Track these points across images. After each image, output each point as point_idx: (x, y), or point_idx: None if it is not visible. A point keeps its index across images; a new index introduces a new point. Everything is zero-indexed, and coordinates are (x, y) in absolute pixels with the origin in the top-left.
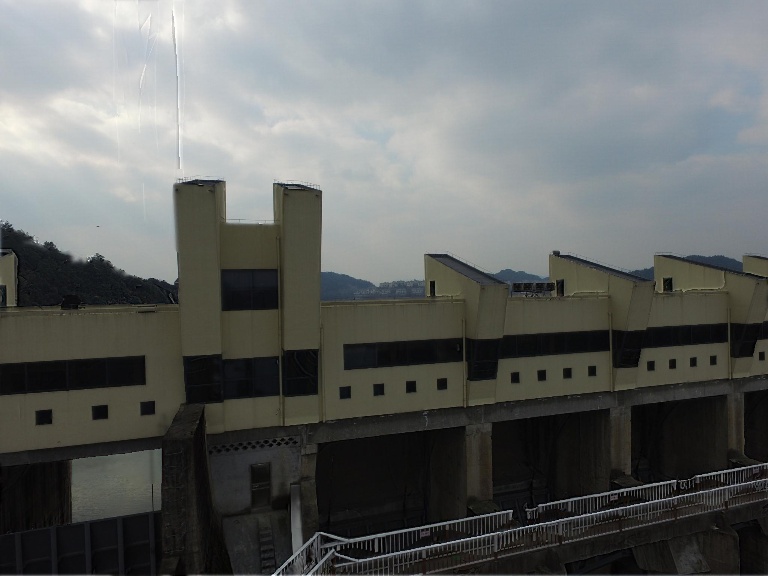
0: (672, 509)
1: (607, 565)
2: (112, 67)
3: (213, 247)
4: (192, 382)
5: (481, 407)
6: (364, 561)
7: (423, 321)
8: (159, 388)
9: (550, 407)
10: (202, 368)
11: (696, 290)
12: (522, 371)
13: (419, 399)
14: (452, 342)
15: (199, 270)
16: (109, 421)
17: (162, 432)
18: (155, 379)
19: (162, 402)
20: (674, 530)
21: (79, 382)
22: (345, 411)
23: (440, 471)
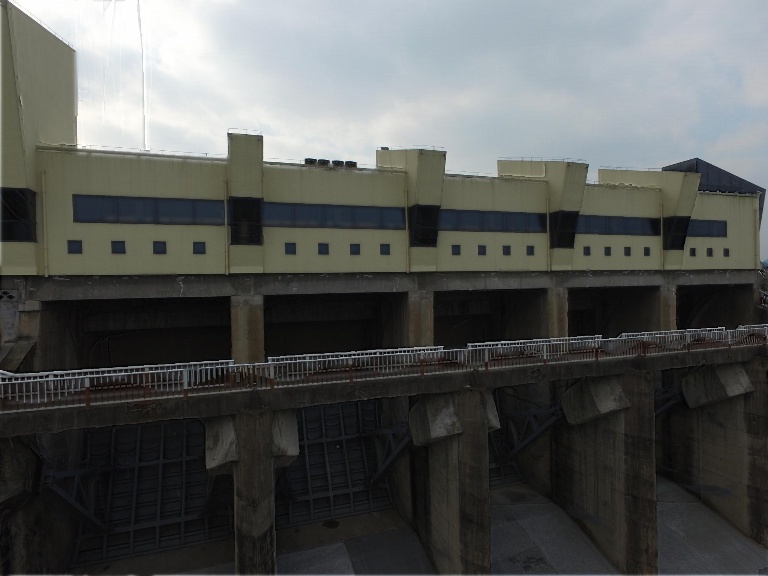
0: (418, 364)
1: (406, 456)
2: None
3: None
4: None
5: (250, 278)
6: (4, 383)
7: (175, 178)
8: None
9: (335, 284)
10: None
11: (510, 176)
12: (299, 242)
13: (170, 262)
14: (212, 204)
15: None
16: None
17: None
18: None
19: None
20: (419, 386)
21: None
22: (75, 267)
23: None
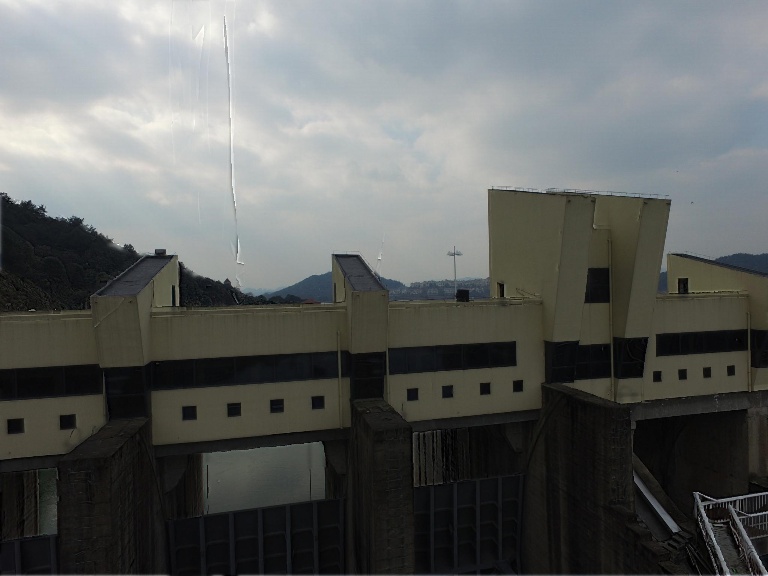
0: None
1: None
2: (168, 76)
3: (586, 249)
4: (555, 364)
5: (759, 392)
6: (753, 516)
7: (716, 314)
8: (526, 369)
9: None
10: (559, 353)
11: None
12: None
13: (713, 384)
14: (738, 333)
15: (574, 268)
16: (491, 396)
17: (528, 407)
18: (522, 361)
19: (528, 381)
20: None
21: (469, 363)
22: (657, 393)
23: (695, 452)
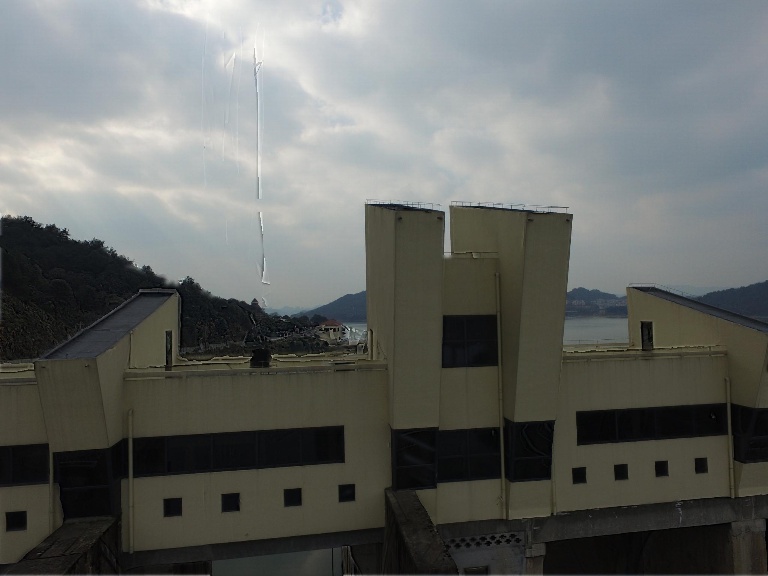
0: None
1: None
2: (200, 103)
3: (437, 290)
4: (402, 462)
5: (750, 497)
6: None
7: (674, 380)
8: (360, 467)
9: None
10: (412, 443)
11: None
12: None
13: (672, 485)
14: (711, 408)
15: (419, 320)
16: (303, 509)
17: (363, 524)
18: (355, 455)
19: (363, 485)
20: None
21: (269, 458)
22: (579, 500)
23: (667, 570)
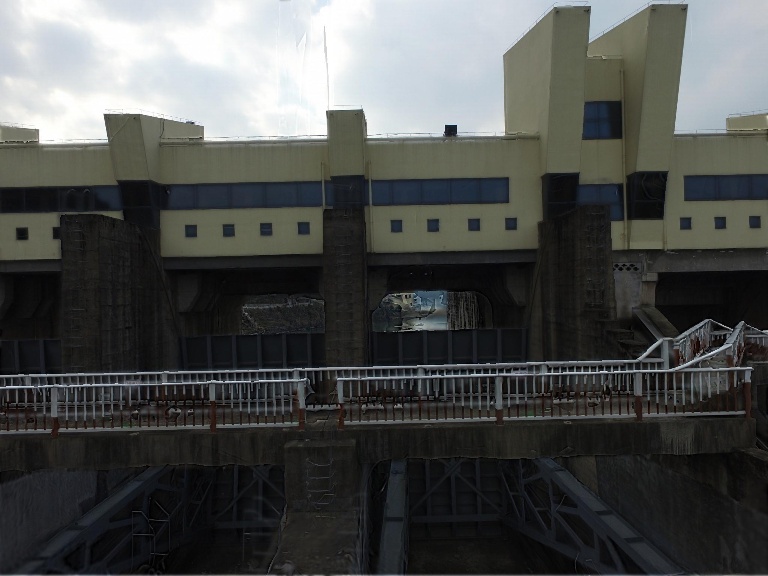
0: None
1: None
2: (275, 84)
3: (582, 67)
4: (551, 199)
5: None
6: None
7: (767, 154)
8: (520, 207)
9: None
10: (558, 189)
11: None
12: None
13: (763, 235)
14: None
15: (568, 90)
16: (481, 233)
17: (523, 246)
18: (516, 199)
19: (522, 219)
20: None
21: (457, 199)
22: (685, 242)
23: None
